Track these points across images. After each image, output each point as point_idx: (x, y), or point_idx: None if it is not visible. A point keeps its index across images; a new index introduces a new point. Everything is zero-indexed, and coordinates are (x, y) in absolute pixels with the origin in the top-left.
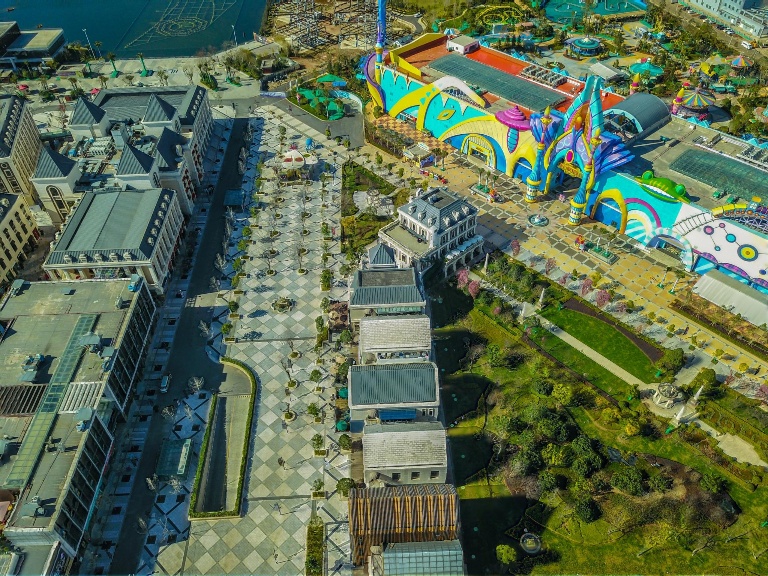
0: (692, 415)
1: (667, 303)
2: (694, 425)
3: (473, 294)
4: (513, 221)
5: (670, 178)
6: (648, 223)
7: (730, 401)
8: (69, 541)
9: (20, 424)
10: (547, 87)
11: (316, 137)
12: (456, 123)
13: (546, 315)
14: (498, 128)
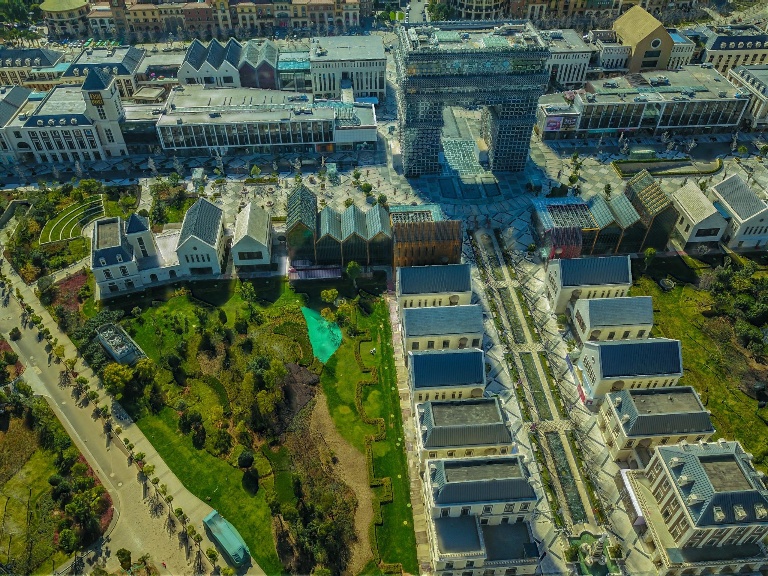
0: None
1: None
2: None
3: None
4: None
5: None
6: None
7: None
8: (582, 122)
9: (627, 86)
10: None
11: None
12: None
13: None
14: None
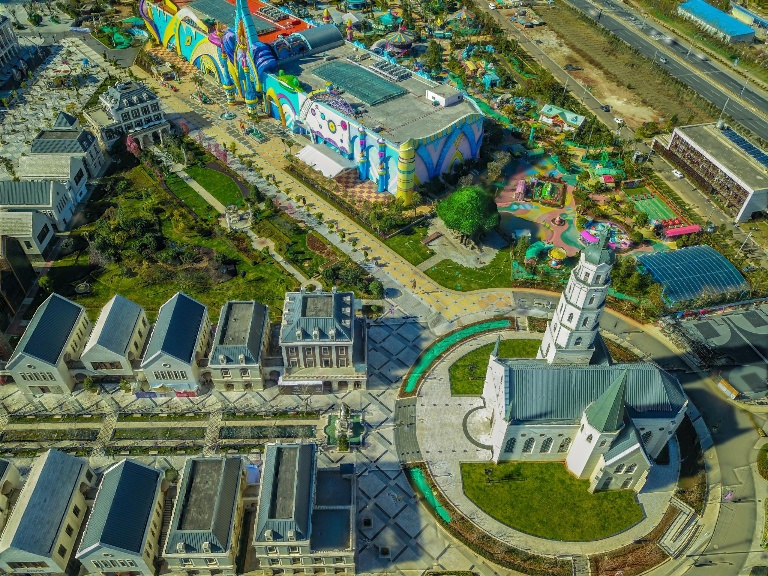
0: (247, 227)
1: (282, 166)
2: (240, 231)
3: (135, 154)
4: (209, 116)
5: (308, 79)
6: (292, 113)
7: (280, 220)
8: None
9: None
10: (270, 21)
11: (97, 60)
12: (194, 47)
13: (188, 171)
14: (212, 47)
